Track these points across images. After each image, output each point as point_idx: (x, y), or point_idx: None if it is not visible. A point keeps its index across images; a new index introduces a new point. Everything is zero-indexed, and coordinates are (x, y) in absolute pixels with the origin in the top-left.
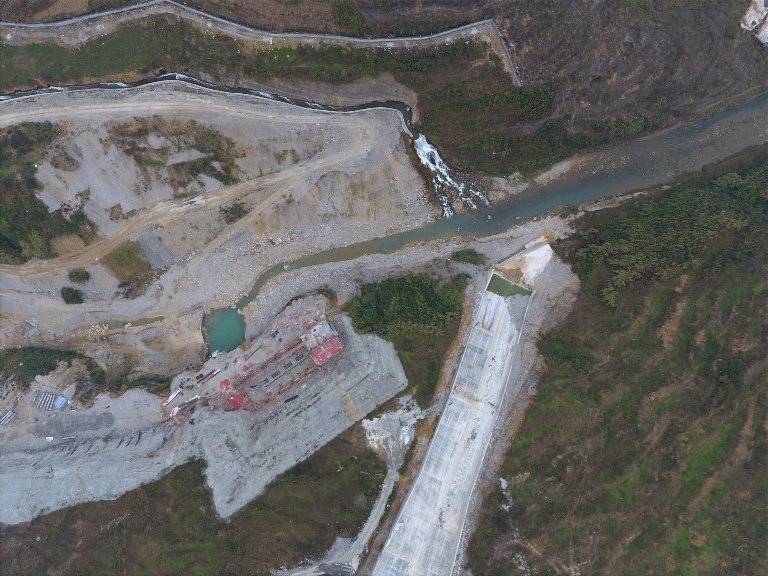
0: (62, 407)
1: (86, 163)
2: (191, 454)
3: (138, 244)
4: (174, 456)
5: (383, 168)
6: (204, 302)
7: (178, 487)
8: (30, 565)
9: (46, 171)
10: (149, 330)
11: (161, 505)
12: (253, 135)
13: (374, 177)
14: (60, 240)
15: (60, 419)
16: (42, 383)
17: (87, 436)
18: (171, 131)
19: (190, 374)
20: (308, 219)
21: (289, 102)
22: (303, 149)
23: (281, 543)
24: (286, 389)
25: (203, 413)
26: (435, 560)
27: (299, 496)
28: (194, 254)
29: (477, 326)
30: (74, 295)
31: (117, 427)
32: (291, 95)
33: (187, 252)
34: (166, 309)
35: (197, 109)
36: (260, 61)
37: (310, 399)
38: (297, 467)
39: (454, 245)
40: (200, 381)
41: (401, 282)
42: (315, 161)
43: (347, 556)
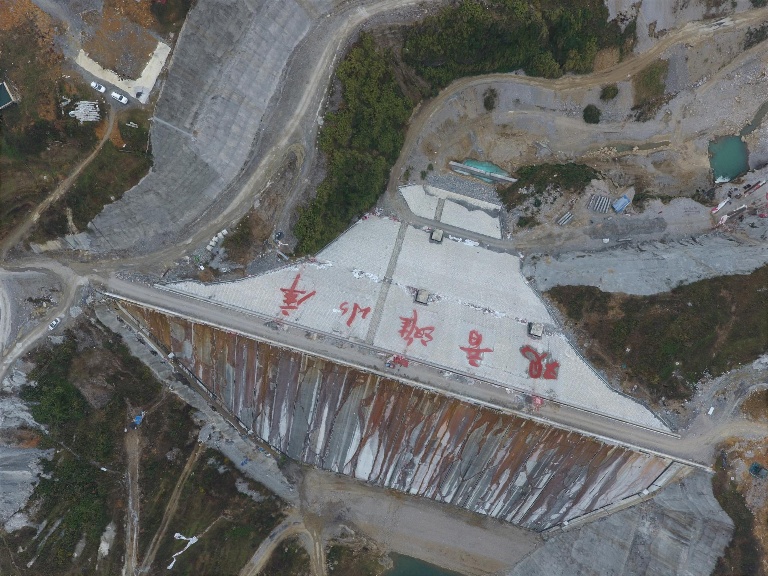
0: (621, 209)
1: None
2: None
3: (668, 63)
4: None
5: None
6: (710, 128)
7: None
8: (692, 325)
9: None
10: (660, 152)
11: None
12: None
13: None
14: (604, 53)
15: (615, 222)
16: (597, 187)
17: (642, 239)
18: None
19: (734, 185)
20: None
21: None
22: None
23: None
24: None
25: (763, 218)
26: None
27: None
28: (705, 80)
29: None
30: (598, 113)
31: (670, 232)
32: None
33: (699, 77)
34: (673, 134)
35: None
36: None
37: None
38: None
39: None
40: (747, 191)
41: None
42: None
43: None
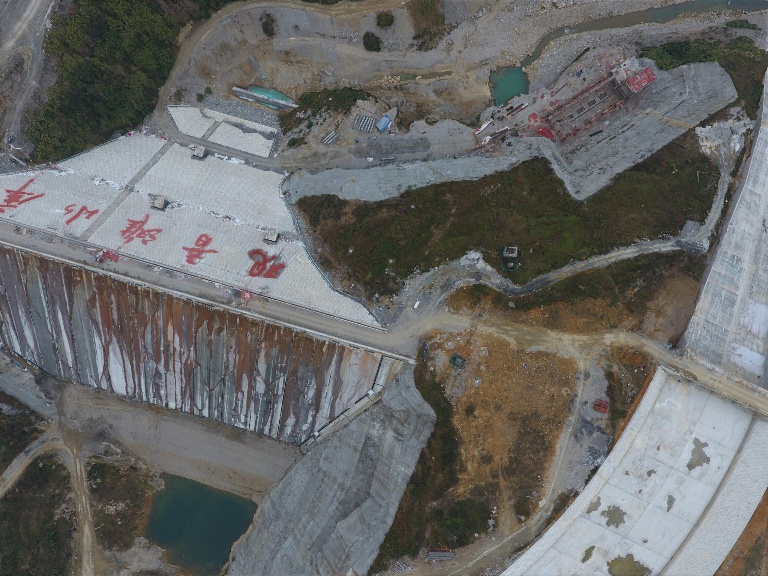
0: (384, 129)
1: None
2: (531, 155)
3: None
4: (515, 156)
5: None
6: (491, 58)
7: (530, 176)
8: (411, 226)
9: None
10: (441, 81)
11: (518, 188)
12: None
13: None
14: None
15: (379, 142)
16: (362, 107)
17: (405, 158)
18: None
19: (498, 108)
20: None
21: None
22: None
23: (637, 222)
24: (595, 120)
25: None
26: (764, 258)
27: (644, 188)
28: (485, 11)
29: (765, 78)
30: (376, 40)
31: (433, 151)
32: None
33: (479, 8)
34: (455, 63)
35: None
36: None
37: (620, 128)
38: (637, 165)
39: (726, 17)
40: (509, 113)
41: None
42: None
43: (698, 237)
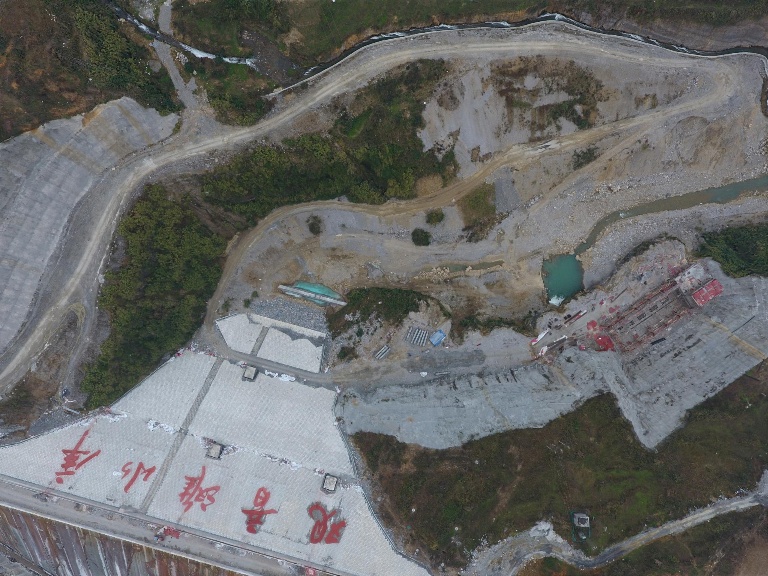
0: (437, 343)
1: (464, 103)
2: (596, 388)
3: (494, 187)
4: (579, 389)
5: (744, 114)
6: (544, 247)
7: (596, 418)
8: (476, 486)
9: (431, 109)
10: (492, 273)
11: (584, 434)
12: (623, 78)
13: (735, 123)
14: (425, 180)
15: (433, 355)
16: (415, 319)
17: (460, 372)
18: (548, 72)
19: (555, 315)
20: (651, 166)
21: (658, 45)
22: (664, 94)
23: (712, 474)
24: (658, 331)
25: (579, 352)
26: None
27: (717, 430)
28: (537, 199)
29: None
30: (426, 237)
31: (488, 364)
32: (663, 38)
33: (531, 197)
34: (506, 253)
35: (576, 50)
36: (650, 1)
37: (685, 341)
38: (709, 402)
39: None
40: (567, 321)
41: (746, 231)
42: (673, 106)
43: None
